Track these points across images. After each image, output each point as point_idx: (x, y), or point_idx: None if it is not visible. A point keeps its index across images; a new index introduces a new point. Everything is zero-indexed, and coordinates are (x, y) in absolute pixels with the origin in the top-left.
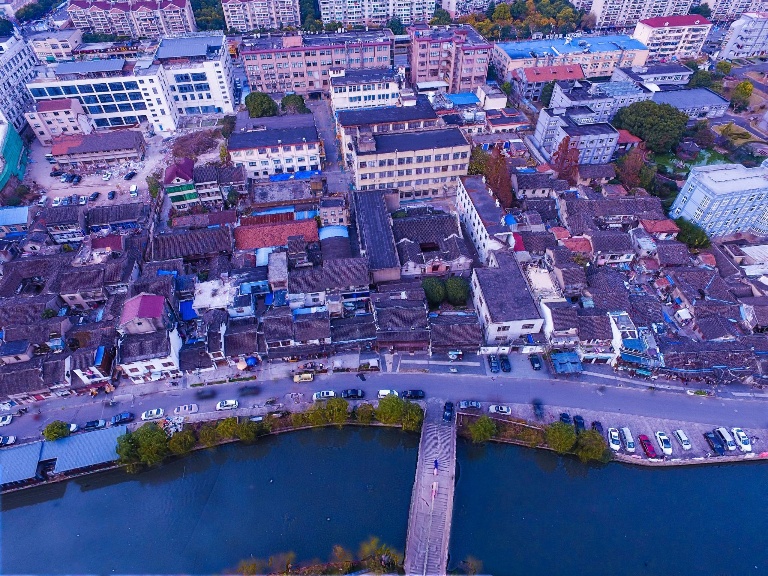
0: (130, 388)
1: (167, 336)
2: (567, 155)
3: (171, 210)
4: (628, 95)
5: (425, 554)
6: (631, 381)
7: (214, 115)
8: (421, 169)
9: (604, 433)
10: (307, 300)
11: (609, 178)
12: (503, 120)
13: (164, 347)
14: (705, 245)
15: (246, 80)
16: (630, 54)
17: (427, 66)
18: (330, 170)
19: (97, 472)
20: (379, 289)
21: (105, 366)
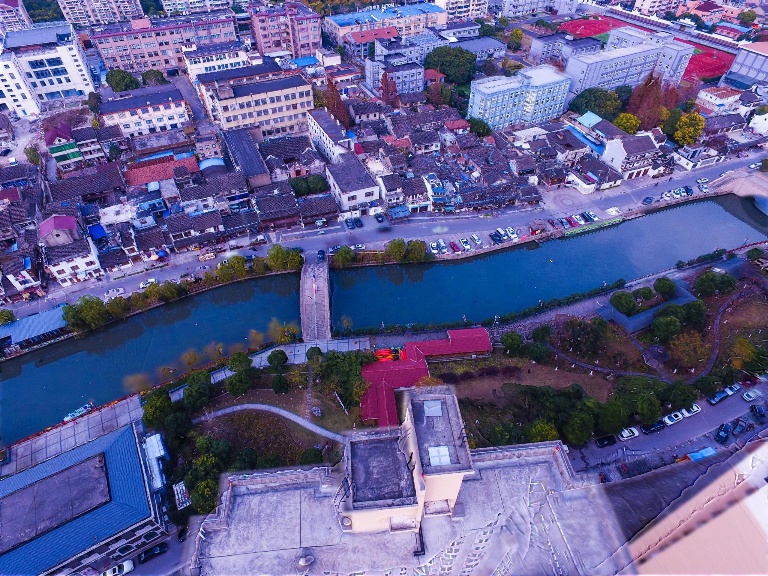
0: (60, 290)
1: (85, 238)
2: (388, 87)
3: (57, 169)
4: (430, 43)
5: (315, 325)
6: (444, 217)
7: (76, 98)
8: (275, 109)
9: (428, 247)
10: (199, 207)
11: (423, 102)
12: (339, 73)
13: (84, 248)
14: (488, 132)
15: (102, 65)
16: (433, 17)
17: (270, 38)
18: (199, 126)
19: (48, 345)
20: (256, 191)
21: (34, 272)
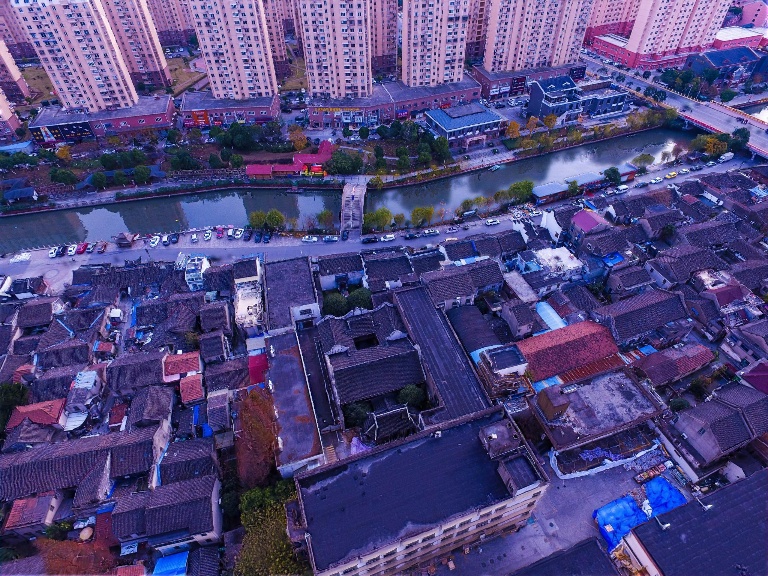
0: None
1: None
2: None
3: None
4: None
5: None
6: None
7: None
8: None
9: None
10: None
11: None
12: None
13: None
14: None
15: None
16: None
17: None
18: None
19: None
20: None
21: None
